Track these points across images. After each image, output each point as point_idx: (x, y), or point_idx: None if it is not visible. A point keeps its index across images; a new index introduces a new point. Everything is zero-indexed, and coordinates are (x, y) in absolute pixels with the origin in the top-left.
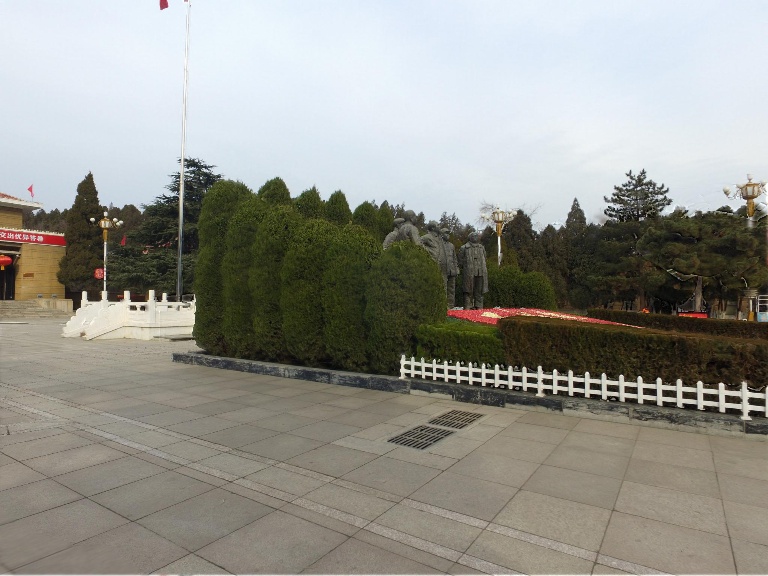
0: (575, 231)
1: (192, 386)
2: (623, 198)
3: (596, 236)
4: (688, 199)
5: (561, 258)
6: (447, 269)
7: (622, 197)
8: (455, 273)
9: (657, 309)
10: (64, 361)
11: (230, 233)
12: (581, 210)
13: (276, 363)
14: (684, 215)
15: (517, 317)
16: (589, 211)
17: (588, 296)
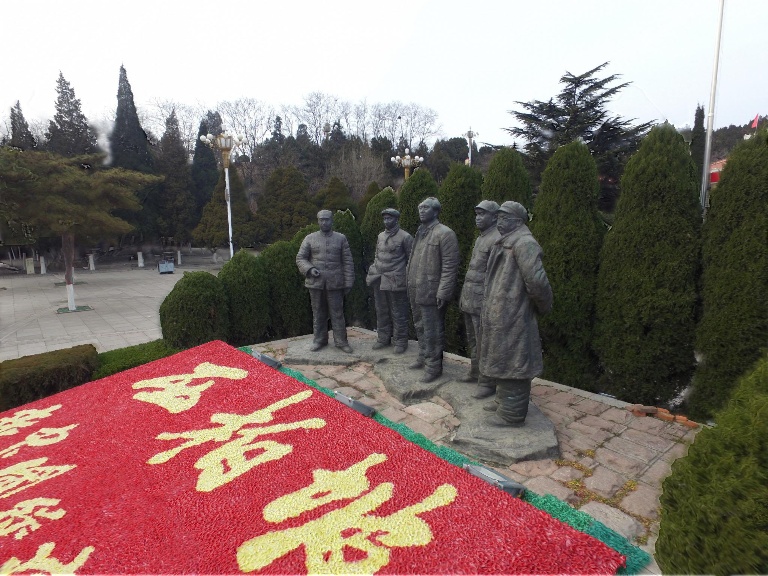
0: None
1: None
2: None
3: None
4: None
5: None
6: (416, 296)
7: None
8: (469, 307)
9: None
10: None
11: None
12: None
13: None
14: None
15: (83, 347)
16: None
17: None
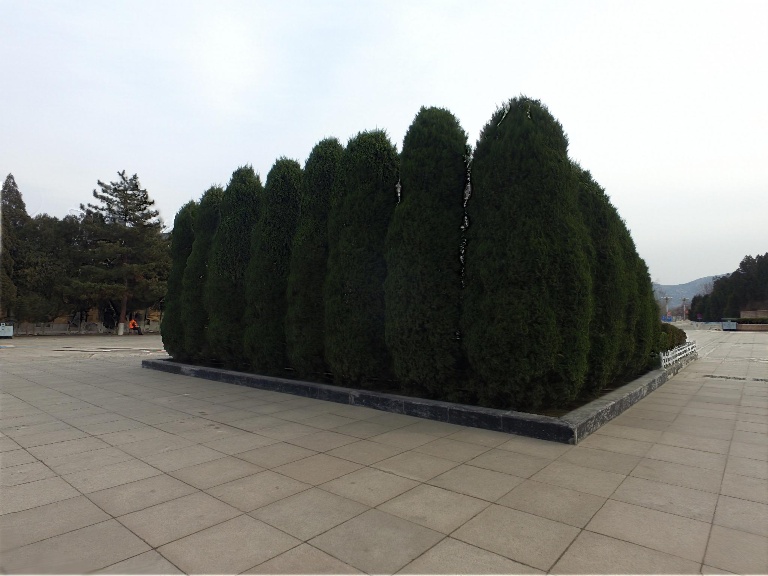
0: (9, 218)
1: (761, 415)
2: (112, 197)
3: (55, 231)
4: (167, 215)
5: (7, 252)
6: None
7: (111, 196)
8: None
9: (105, 320)
10: (737, 574)
11: (615, 215)
12: (18, 192)
13: (623, 387)
14: (162, 229)
15: None
16: (36, 197)
17: (49, 305)
